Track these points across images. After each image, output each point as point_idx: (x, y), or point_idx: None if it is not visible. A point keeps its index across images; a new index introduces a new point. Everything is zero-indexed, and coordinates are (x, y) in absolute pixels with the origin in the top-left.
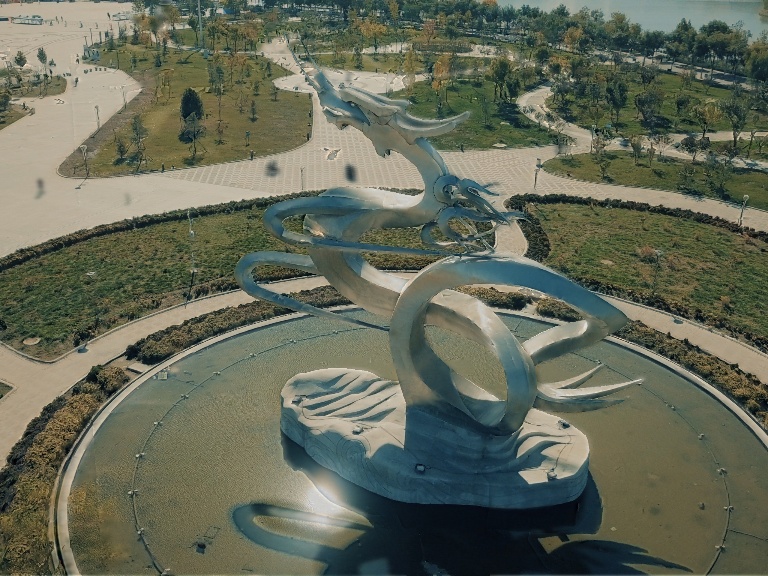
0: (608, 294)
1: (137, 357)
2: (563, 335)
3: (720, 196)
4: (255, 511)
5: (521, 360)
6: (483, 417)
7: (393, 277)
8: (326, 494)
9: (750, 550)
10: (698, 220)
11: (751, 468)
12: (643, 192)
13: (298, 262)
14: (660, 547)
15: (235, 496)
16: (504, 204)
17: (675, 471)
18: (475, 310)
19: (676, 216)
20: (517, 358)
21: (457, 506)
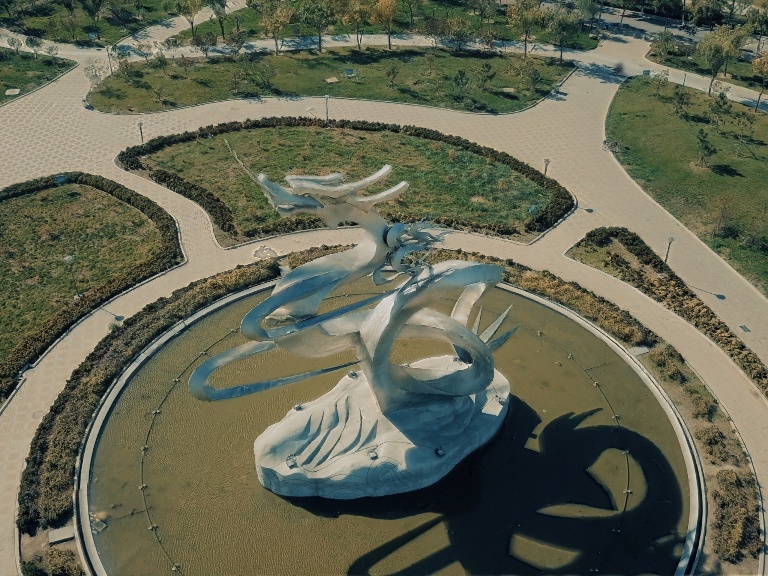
0: (317, 227)
1: (39, 527)
2: (471, 302)
3: (273, 92)
4: (361, 569)
5: (478, 337)
6: (458, 390)
7: (338, 320)
8: (384, 517)
9: (607, 376)
10: (289, 125)
11: (547, 322)
12: (212, 108)
13: (256, 349)
14: (575, 405)
15: (332, 570)
16: (120, 167)
17: (520, 349)
18: (422, 316)
19: (269, 126)
20: (477, 337)
21: (462, 461)
